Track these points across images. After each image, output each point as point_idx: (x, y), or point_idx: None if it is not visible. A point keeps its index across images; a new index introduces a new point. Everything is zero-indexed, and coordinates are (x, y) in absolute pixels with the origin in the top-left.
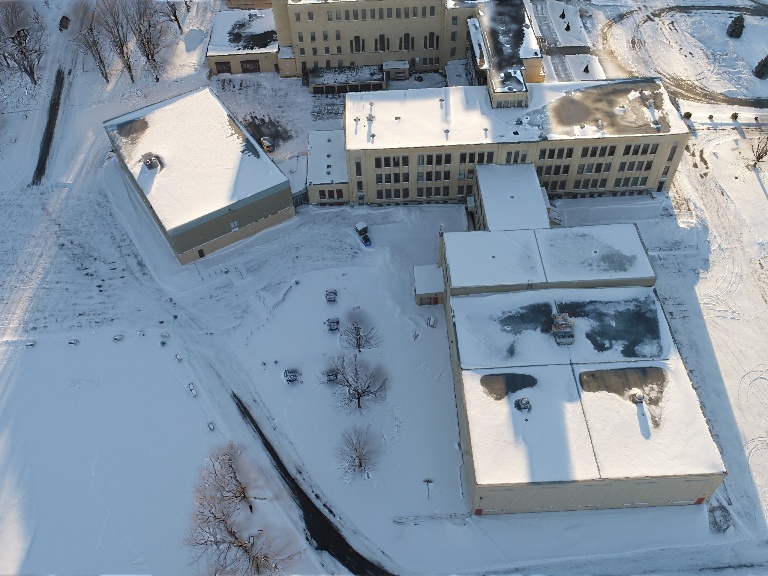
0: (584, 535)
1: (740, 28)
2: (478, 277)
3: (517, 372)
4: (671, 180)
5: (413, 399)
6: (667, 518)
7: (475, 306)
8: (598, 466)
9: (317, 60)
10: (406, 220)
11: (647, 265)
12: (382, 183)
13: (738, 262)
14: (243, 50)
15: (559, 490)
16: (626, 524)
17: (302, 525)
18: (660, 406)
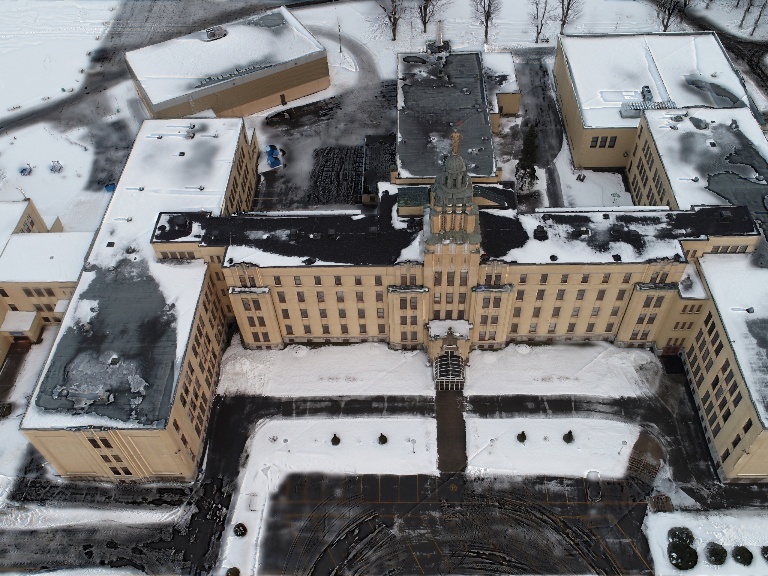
0: None
1: None
2: None
3: None
4: None
5: None
6: None
7: None
8: None
9: None
10: None
11: None
12: None
13: None
14: None
15: None
16: None
17: None
18: None
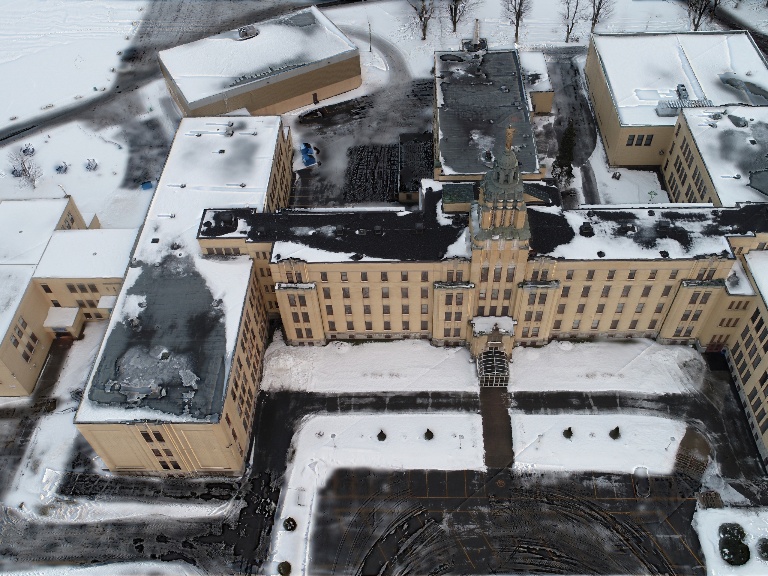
0: None
1: None
2: (3, 218)
3: None
4: None
5: None
6: None
7: None
8: None
9: None
10: None
11: None
12: None
13: None
14: None
15: None
16: None
17: None
18: None
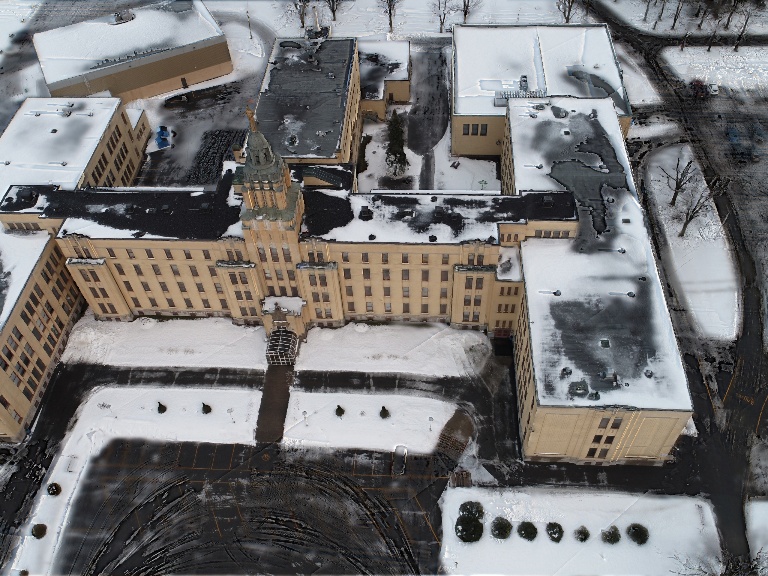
0: None
1: None
2: None
3: None
4: None
5: None
6: None
7: None
8: None
9: None
10: None
11: None
12: None
13: None
14: None
15: None
16: None
17: None
18: None
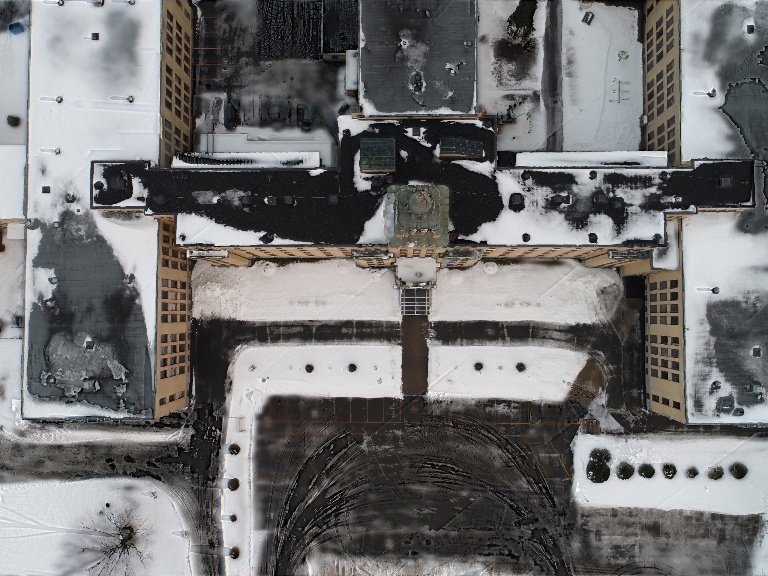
0: None
1: None
2: None
3: None
4: None
5: None
6: None
7: None
8: None
9: None
10: None
11: None
12: None
13: None
14: None
15: None
16: None
17: None
18: None
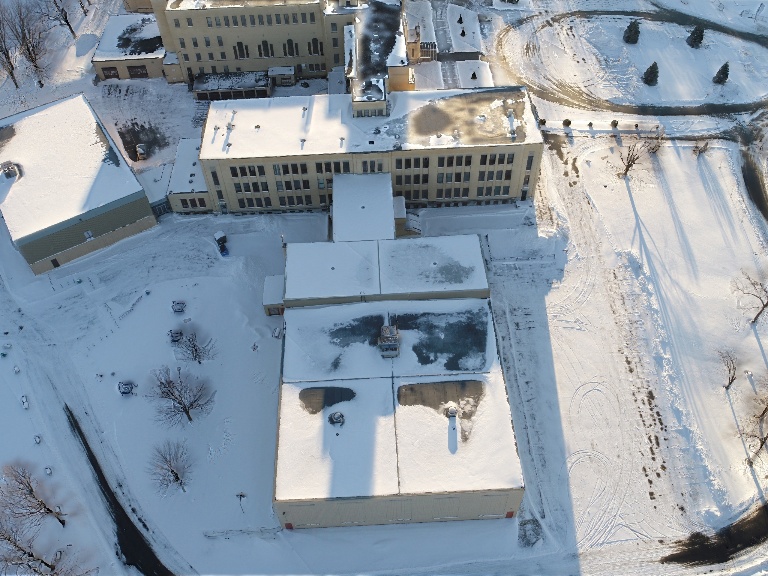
0: (392, 549)
1: (635, 34)
2: (313, 289)
3: (337, 385)
4: (534, 189)
5: (246, 411)
6: (477, 532)
7: (308, 318)
8: (399, 481)
9: (202, 66)
10: (267, 229)
11: (483, 277)
12: (242, 192)
13: (592, 272)
14: (129, 55)
15: (361, 505)
16: (435, 538)
17: (114, 539)
18: (472, 420)
